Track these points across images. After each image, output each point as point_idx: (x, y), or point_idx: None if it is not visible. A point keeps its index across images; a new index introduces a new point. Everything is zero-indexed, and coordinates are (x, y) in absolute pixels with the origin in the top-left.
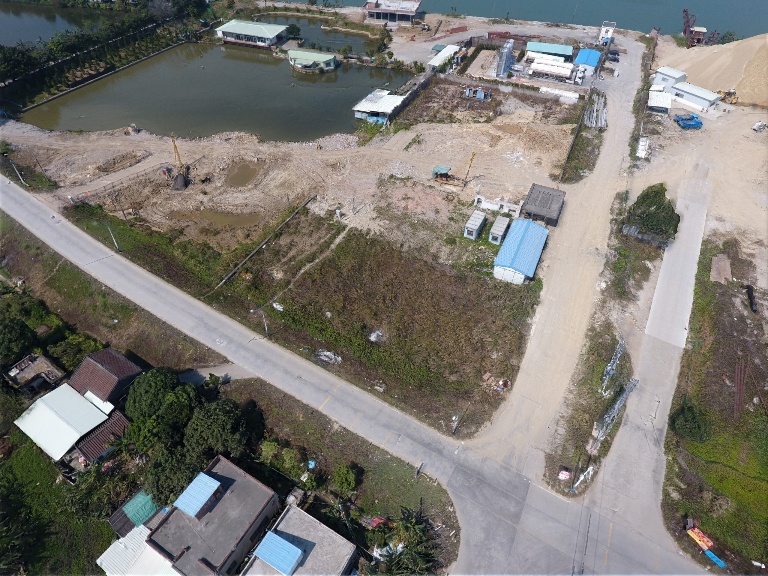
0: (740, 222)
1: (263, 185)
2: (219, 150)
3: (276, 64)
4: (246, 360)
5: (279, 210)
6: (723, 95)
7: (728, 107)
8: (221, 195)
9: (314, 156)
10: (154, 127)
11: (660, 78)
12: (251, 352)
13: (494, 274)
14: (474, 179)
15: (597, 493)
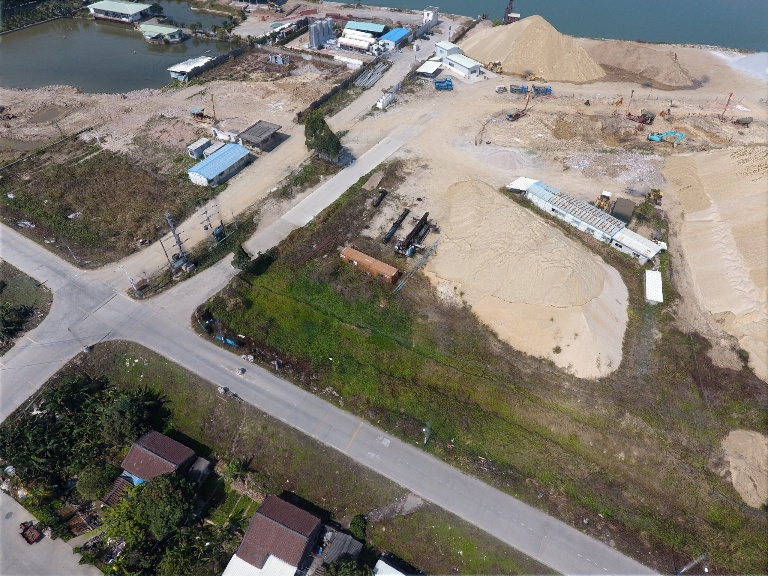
0: (422, 153)
1: (60, 123)
2: (38, 98)
3: (140, 38)
4: None
5: None
6: (491, 66)
7: (491, 75)
8: (20, 128)
9: (116, 103)
10: None
11: (438, 50)
12: None
13: (191, 179)
14: (227, 119)
15: (159, 299)
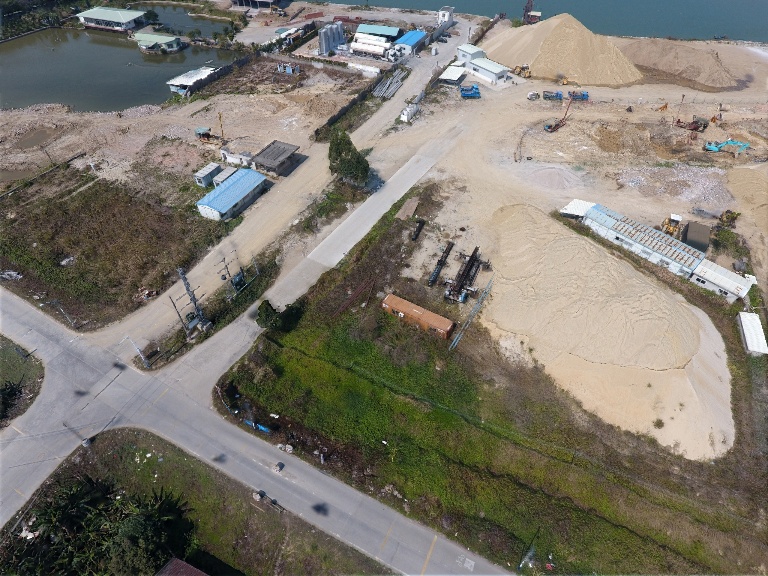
0: (458, 173)
1: (50, 147)
2: (25, 118)
3: (134, 48)
4: None
5: None
6: (518, 70)
7: (520, 80)
8: (5, 155)
9: (111, 123)
10: None
11: (461, 54)
12: None
13: (201, 213)
14: (236, 139)
15: (172, 369)
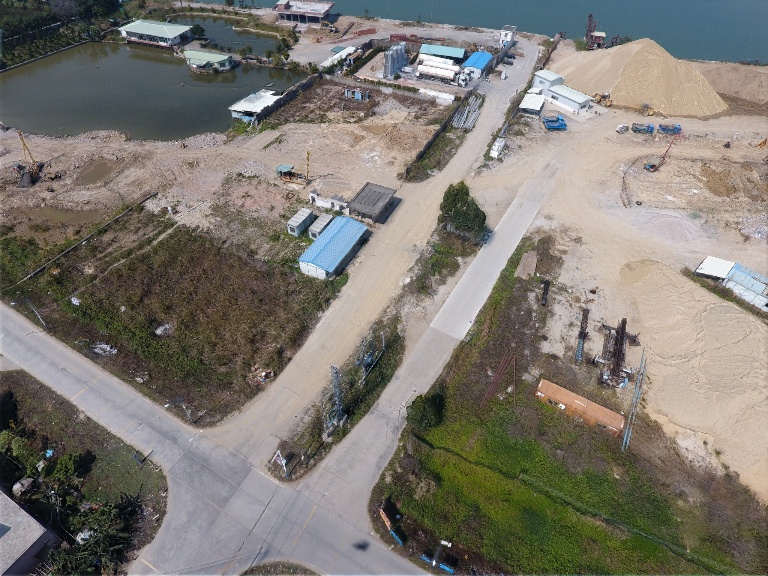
0: (567, 220)
1: (114, 183)
2: (82, 148)
3: (180, 64)
4: (16, 353)
5: (119, 207)
6: (599, 98)
7: (601, 109)
8: (67, 192)
9: (175, 155)
10: (25, 125)
11: (538, 81)
12: (24, 345)
13: (301, 269)
14: (320, 178)
15: (314, 478)
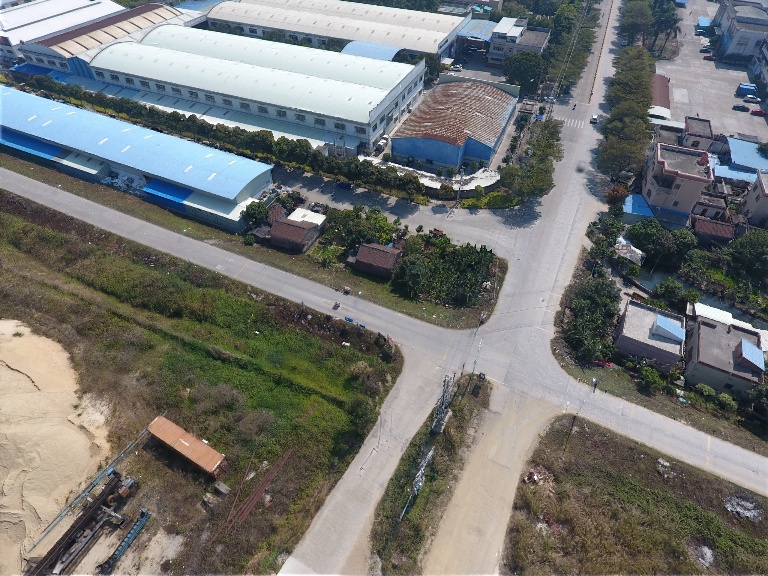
0: None
1: None
2: None
3: None
4: None
5: None
6: None
7: None
8: None
9: None
10: None
11: None
12: None
13: None
14: None
15: None
